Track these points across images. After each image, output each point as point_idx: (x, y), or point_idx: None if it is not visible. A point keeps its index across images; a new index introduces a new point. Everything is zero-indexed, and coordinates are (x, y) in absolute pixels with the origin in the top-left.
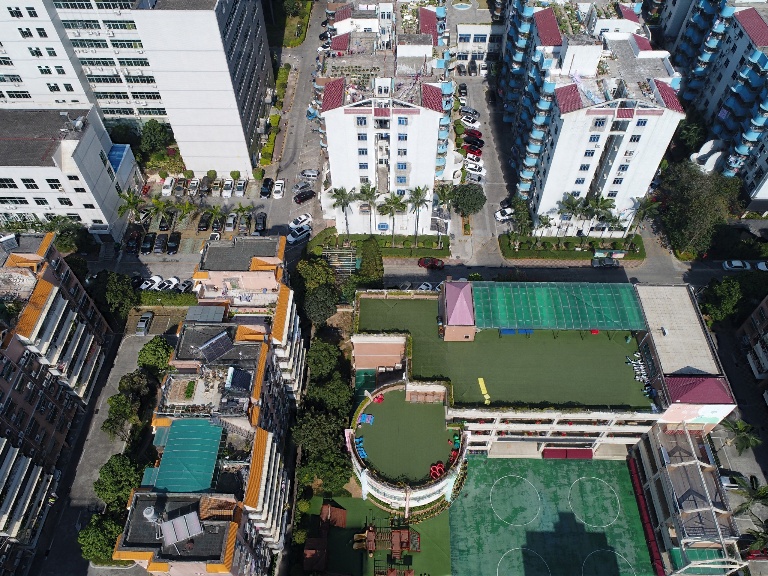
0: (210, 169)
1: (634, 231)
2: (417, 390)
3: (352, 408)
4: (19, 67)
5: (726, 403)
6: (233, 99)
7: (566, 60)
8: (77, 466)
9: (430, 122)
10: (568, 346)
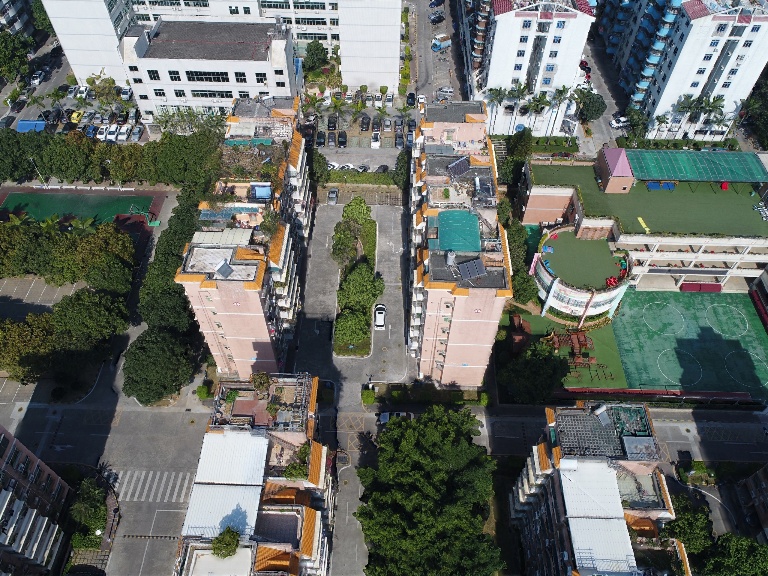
0: (362, 84)
1: (729, 137)
2: (589, 225)
3: (527, 248)
4: None
5: None
6: (399, 16)
7: None
8: (304, 292)
9: (583, 26)
10: (705, 198)
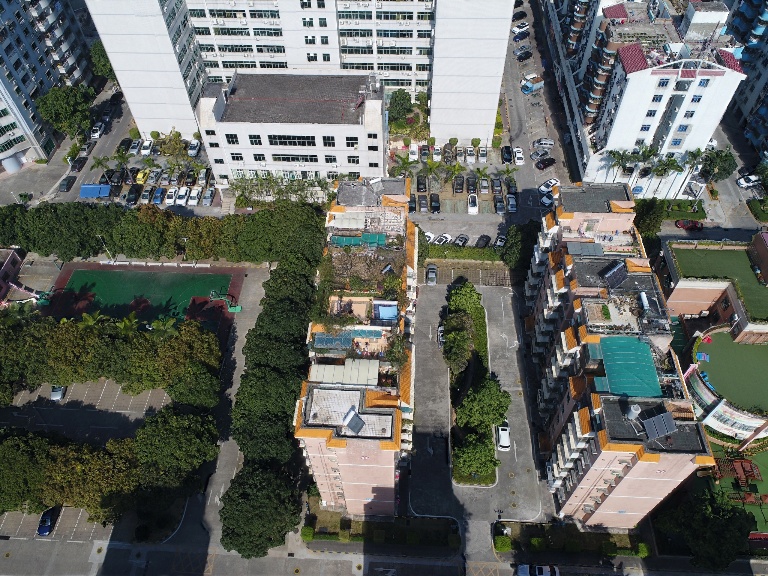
0: (452, 137)
1: None
2: (754, 330)
3: None
4: (287, 37)
5: None
6: (502, 67)
7: None
8: None
9: (730, 84)
10: None
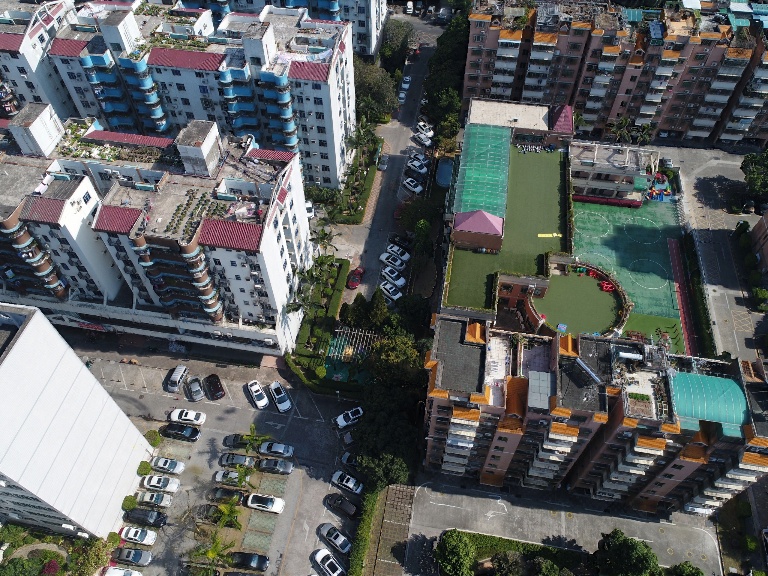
0: (121, 503)
1: None
2: None
3: None
4: None
5: (572, 111)
6: (101, 391)
7: (265, 53)
8: None
9: (297, 169)
10: (509, 179)
